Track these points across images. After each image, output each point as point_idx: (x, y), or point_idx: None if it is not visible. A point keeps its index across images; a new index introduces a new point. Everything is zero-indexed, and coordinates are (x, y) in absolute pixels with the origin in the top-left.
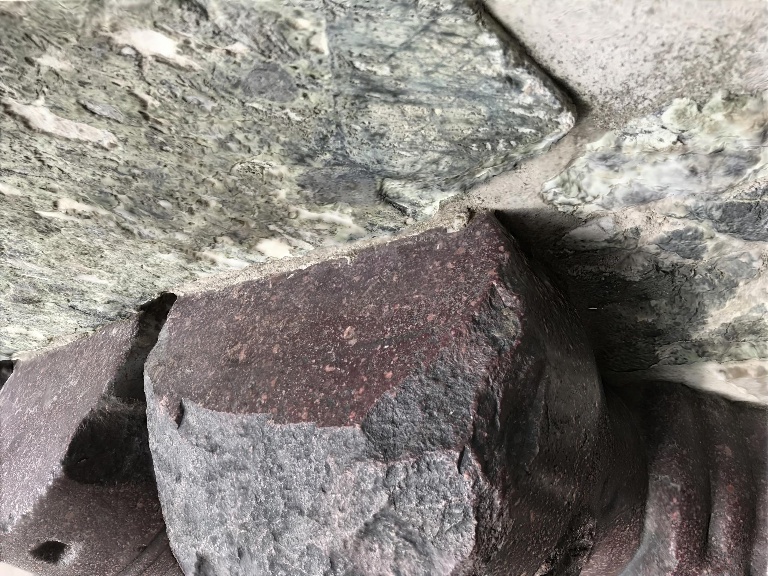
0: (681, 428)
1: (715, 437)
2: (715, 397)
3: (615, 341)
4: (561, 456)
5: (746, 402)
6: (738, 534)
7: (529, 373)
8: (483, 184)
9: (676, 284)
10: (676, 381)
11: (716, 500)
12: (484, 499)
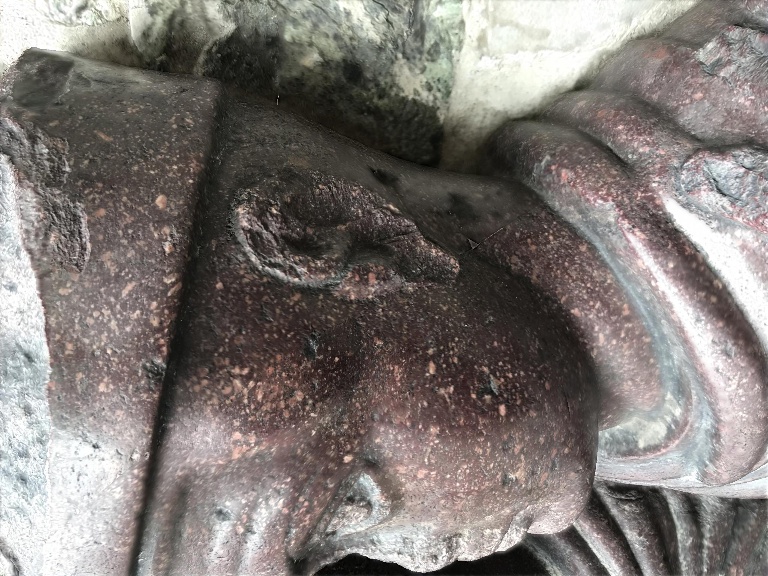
0: (521, 132)
1: (566, 111)
2: (553, 100)
3: (364, 123)
4: (130, 96)
5: (587, 78)
6: (642, 126)
7: (44, 67)
8: (0, 46)
9: (266, 2)
10: (500, 121)
11: (599, 133)
12: (4, 136)
